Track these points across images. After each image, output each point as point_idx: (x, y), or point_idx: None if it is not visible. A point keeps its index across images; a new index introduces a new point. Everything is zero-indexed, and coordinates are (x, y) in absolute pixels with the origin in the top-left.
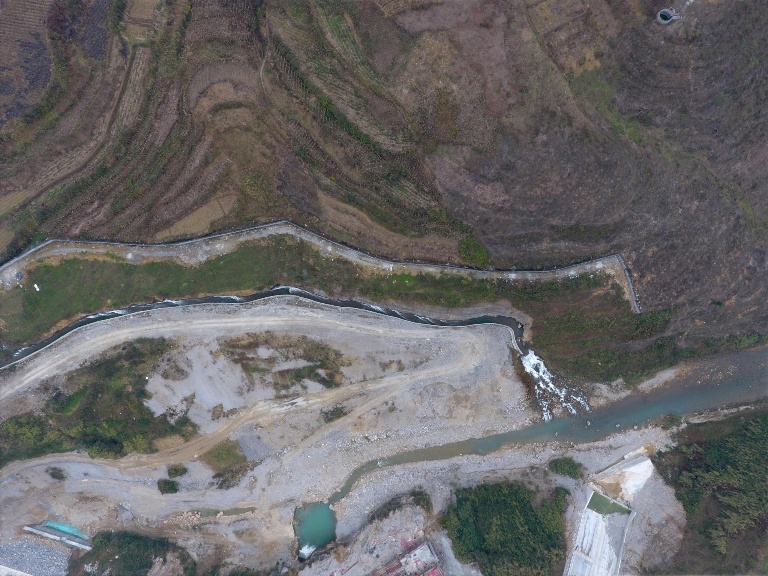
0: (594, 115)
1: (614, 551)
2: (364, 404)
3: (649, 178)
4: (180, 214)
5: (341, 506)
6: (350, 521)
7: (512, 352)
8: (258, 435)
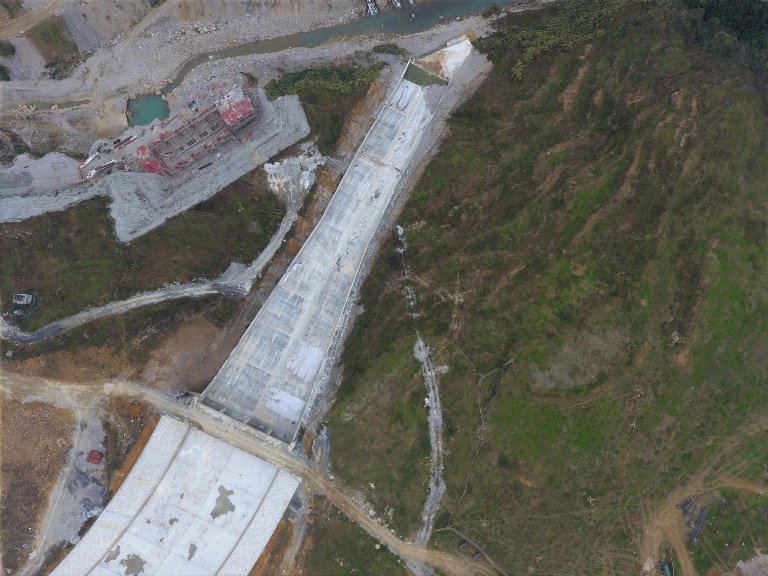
0: None
1: (430, 111)
2: None
3: None
4: None
5: (173, 95)
6: None
7: None
8: (83, 12)
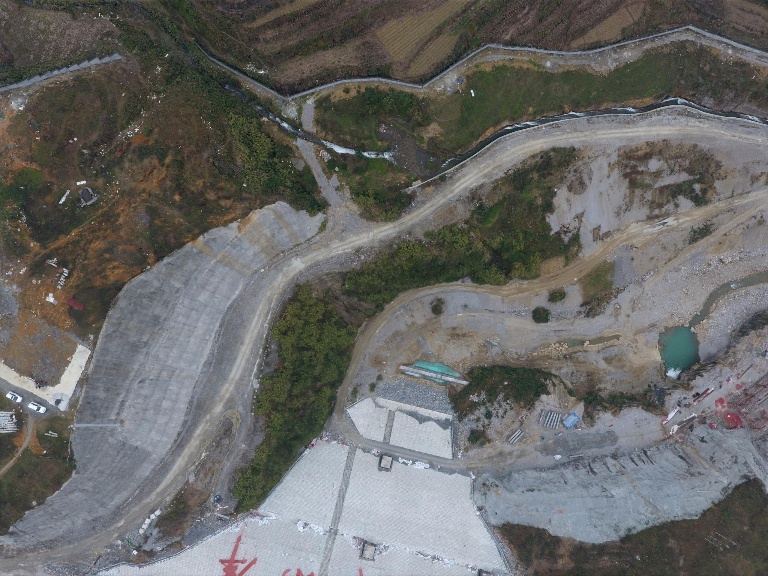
0: None
1: None
2: (730, 221)
3: None
4: (595, 21)
5: (703, 328)
6: (715, 341)
7: None
8: (632, 256)
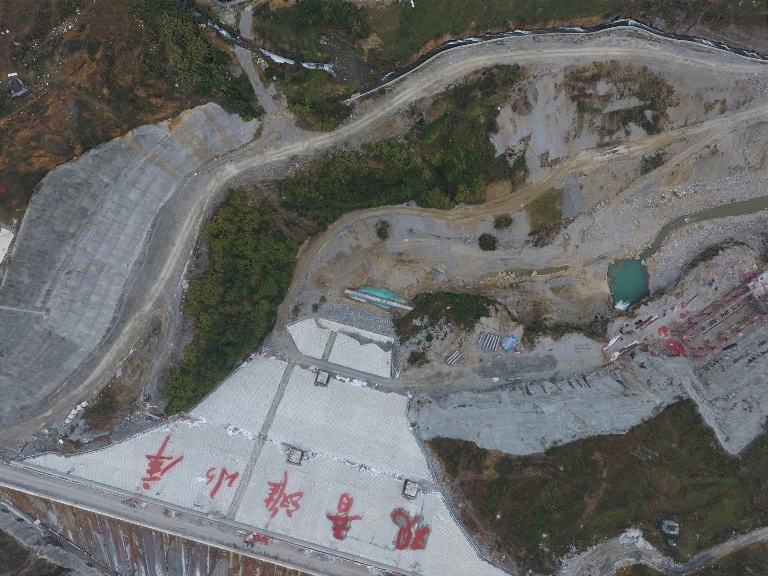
0: None
1: None
2: (683, 151)
3: None
4: None
5: (654, 261)
6: (665, 274)
7: None
8: (581, 184)
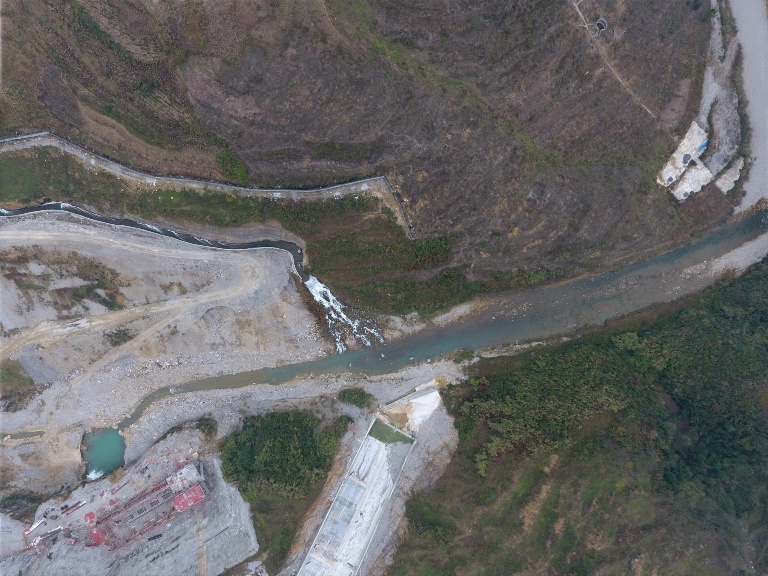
0: (353, 34)
1: (391, 478)
2: (149, 327)
3: (409, 100)
4: None
5: (130, 432)
6: (137, 446)
7: (294, 277)
8: (40, 356)
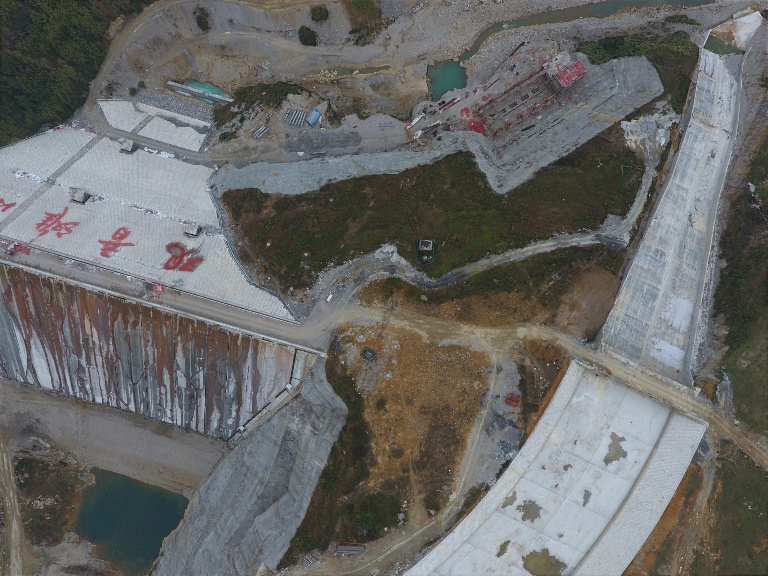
0: None
1: (734, 78)
2: None
3: None
4: None
5: (471, 62)
6: (481, 74)
7: None
8: None
